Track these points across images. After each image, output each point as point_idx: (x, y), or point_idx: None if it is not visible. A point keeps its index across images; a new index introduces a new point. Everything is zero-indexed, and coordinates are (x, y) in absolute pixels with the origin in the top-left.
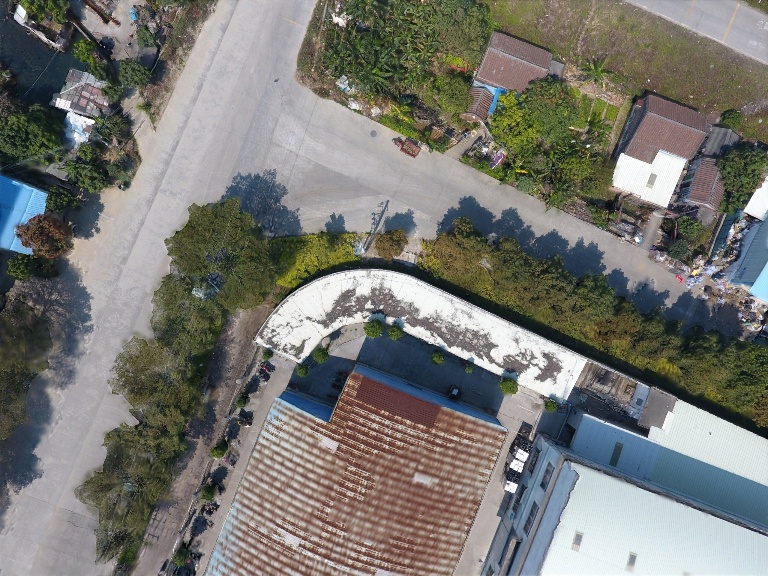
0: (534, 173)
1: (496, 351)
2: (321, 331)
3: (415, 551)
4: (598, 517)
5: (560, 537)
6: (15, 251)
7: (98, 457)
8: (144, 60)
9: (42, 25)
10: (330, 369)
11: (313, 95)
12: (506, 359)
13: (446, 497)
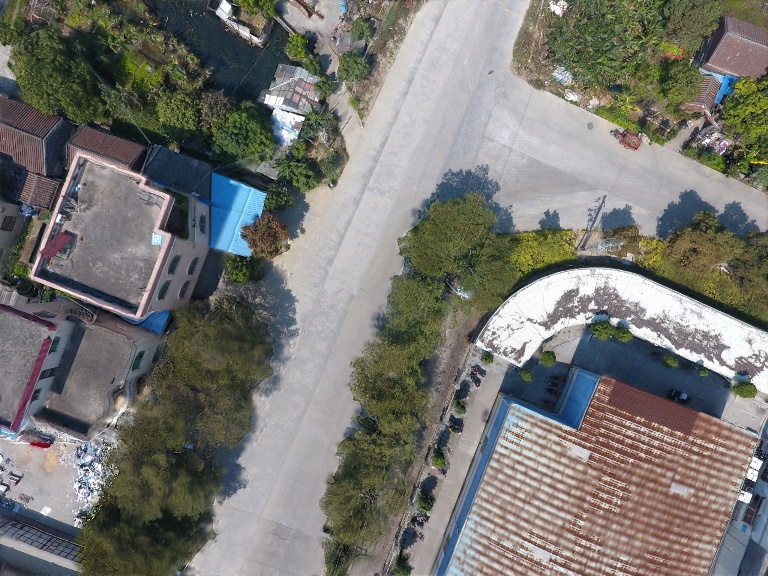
0: None
1: (727, 353)
2: (542, 333)
3: (669, 566)
4: None
5: None
6: (233, 253)
7: (304, 466)
8: None
9: (241, 20)
10: (543, 373)
11: (528, 87)
12: (738, 361)
13: (700, 509)
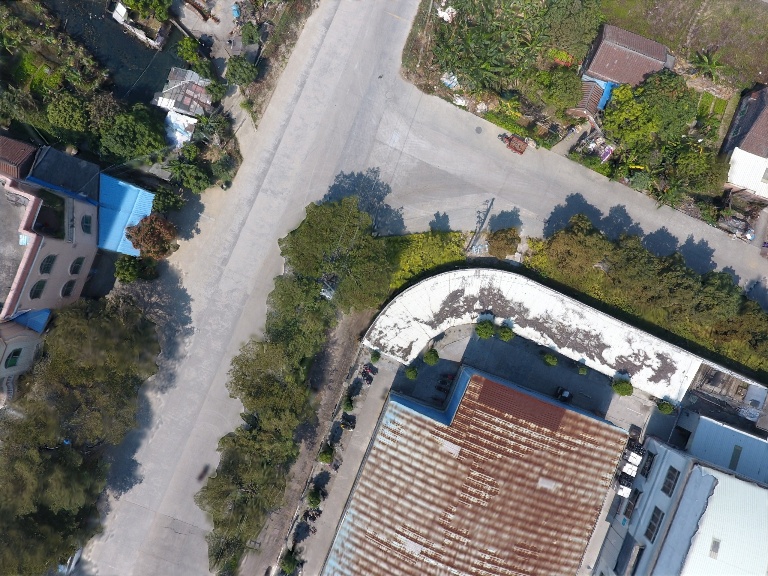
0: (648, 169)
1: (608, 352)
2: (429, 332)
3: (538, 558)
4: (734, 523)
5: (697, 544)
6: (121, 253)
7: (199, 462)
8: (247, 57)
9: (139, 23)
10: (434, 371)
11: (418, 91)
12: (618, 360)
13: (569, 502)
